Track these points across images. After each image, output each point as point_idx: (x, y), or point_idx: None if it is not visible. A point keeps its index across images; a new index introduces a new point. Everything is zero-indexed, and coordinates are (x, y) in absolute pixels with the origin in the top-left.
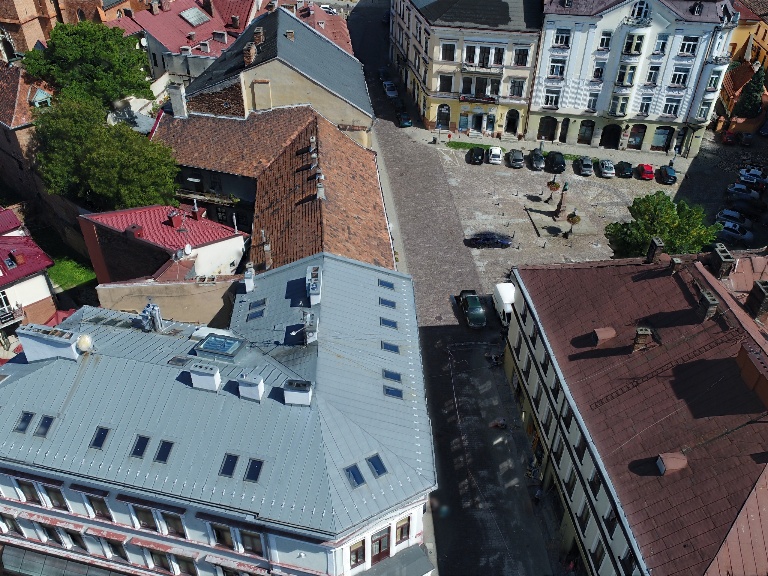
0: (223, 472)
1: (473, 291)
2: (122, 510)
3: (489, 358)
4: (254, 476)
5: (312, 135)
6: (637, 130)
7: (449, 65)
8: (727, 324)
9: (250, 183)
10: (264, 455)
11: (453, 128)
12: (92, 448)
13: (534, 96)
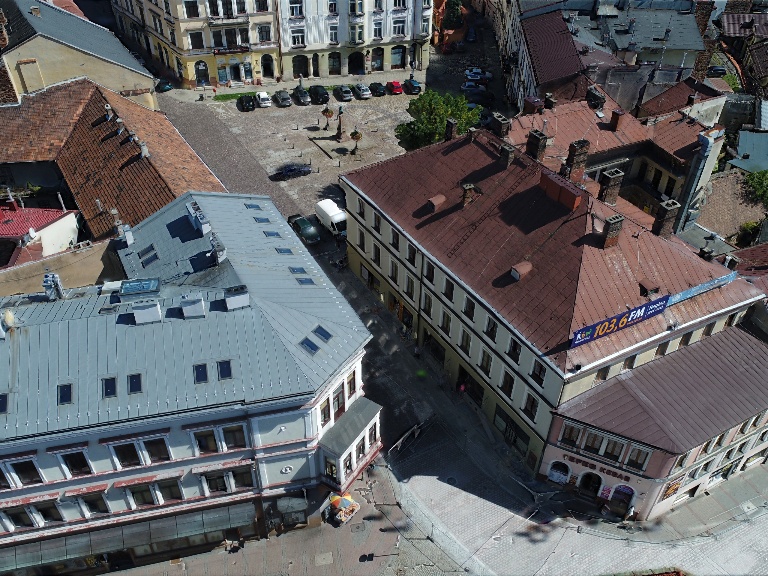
0: (198, 381)
1: (298, 215)
2: (102, 456)
3: (334, 264)
4: (227, 374)
5: (102, 105)
6: (376, 54)
7: (196, 22)
8: (524, 164)
9: (47, 168)
10: (228, 356)
11: (214, 83)
12: (61, 405)
13: (282, 38)
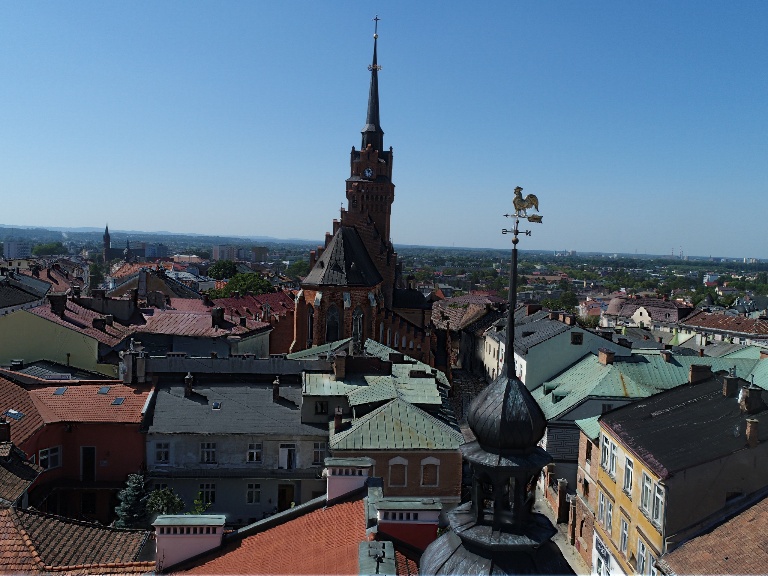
0: None
1: None
2: None
3: None
4: None
5: None
6: None
7: None
8: None
9: None
10: None
11: None
12: None
13: None
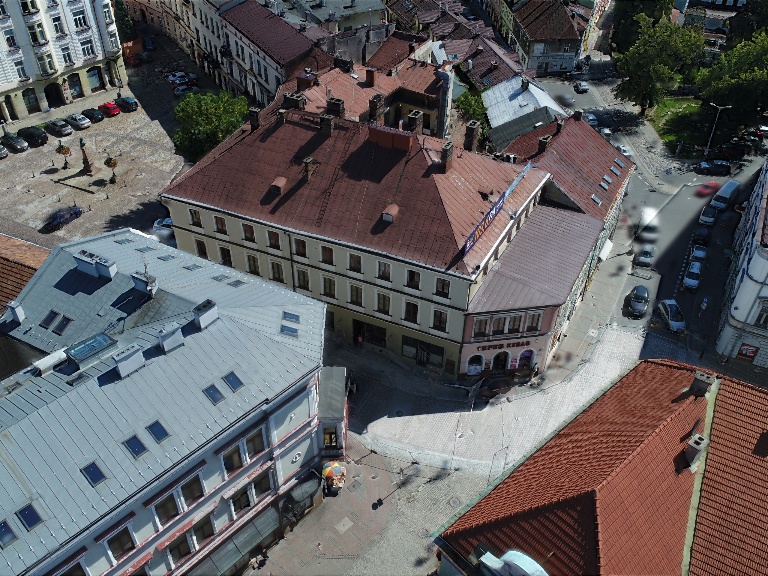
0: (215, 402)
1: None
2: (145, 523)
3: None
4: (238, 384)
5: None
6: (72, 81)
7: None
8: (345, 127)
9: None
10: (228, 369)
11: None
12: (97, 486)
13: None
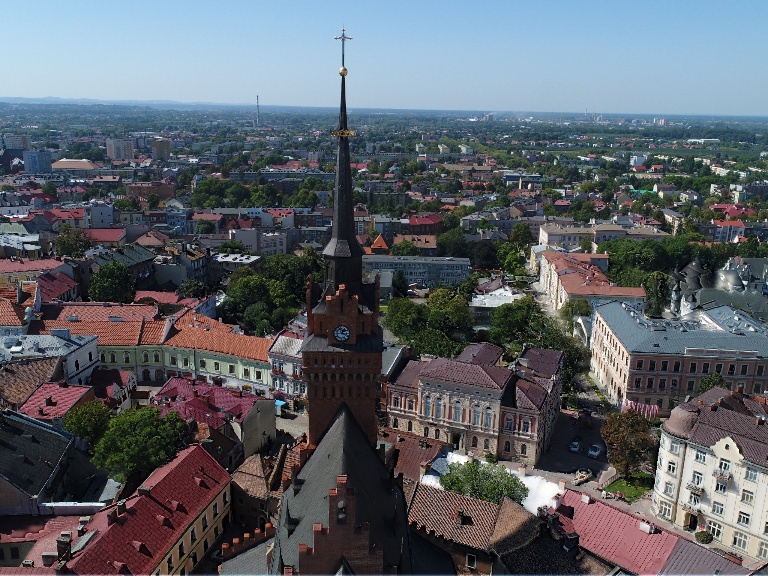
0: None
1: None
2: None
3: None
4: None
5: None
6: None
7: None
8: None
9: None
10: None
11: None
12: None
13: None
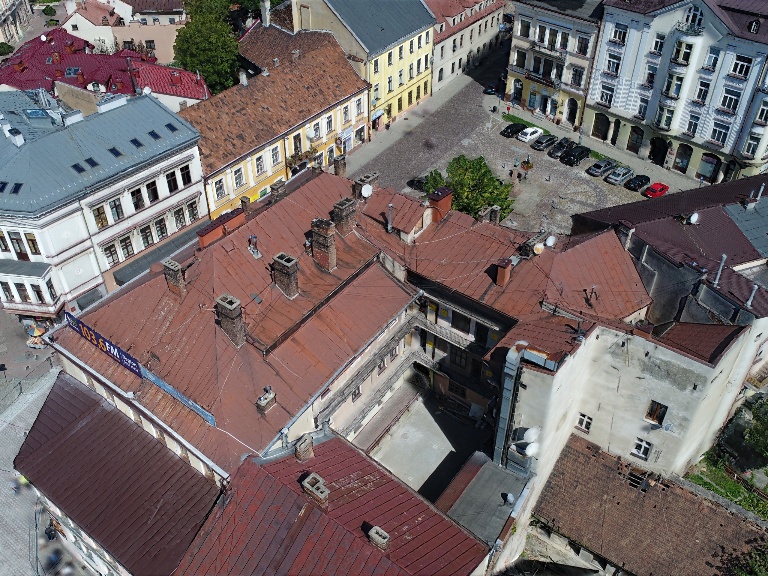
0: None
1: None
2: None
3: None
4: None
5: None
6: (685, 151)
7: (525, 41)
8: None
9: None
10: None
11: (523, 104)
12: None
13: (591, 89)
